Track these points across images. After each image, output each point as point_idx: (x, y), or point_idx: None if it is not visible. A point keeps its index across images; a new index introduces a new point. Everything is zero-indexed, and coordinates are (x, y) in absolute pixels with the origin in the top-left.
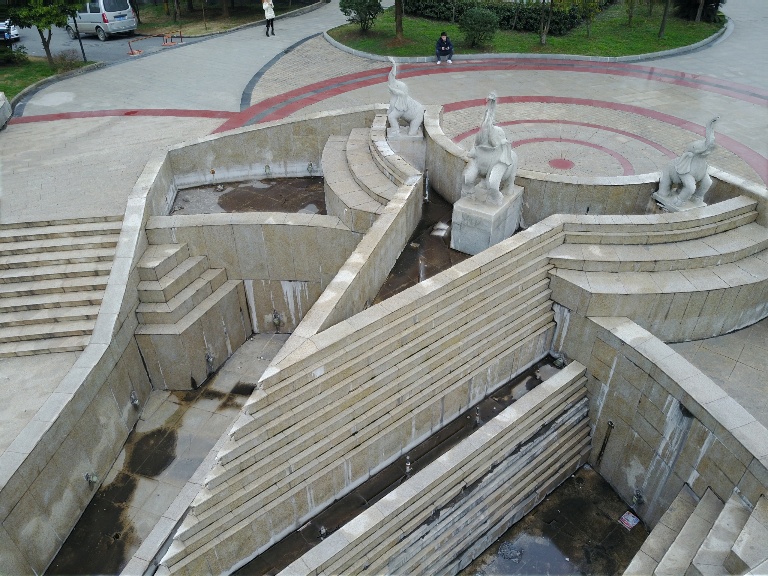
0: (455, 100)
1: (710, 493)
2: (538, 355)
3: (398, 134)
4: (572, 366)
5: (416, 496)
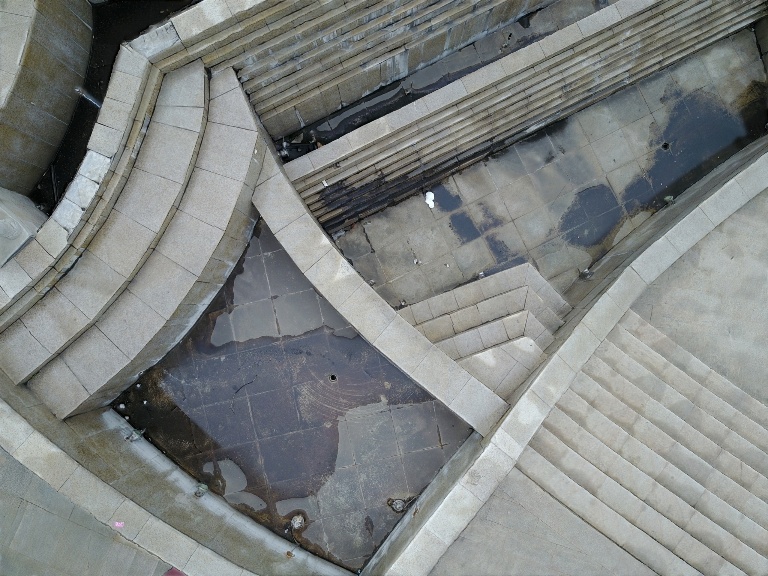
0: None
1: None
2: None
3: (9, 220)
4: None
5: None
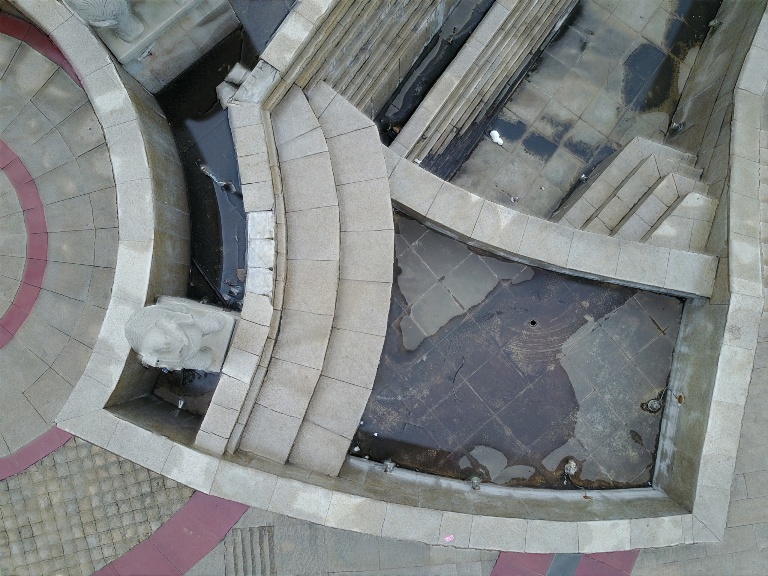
0: None
1: None
2: None
3: None
4: None
5: None
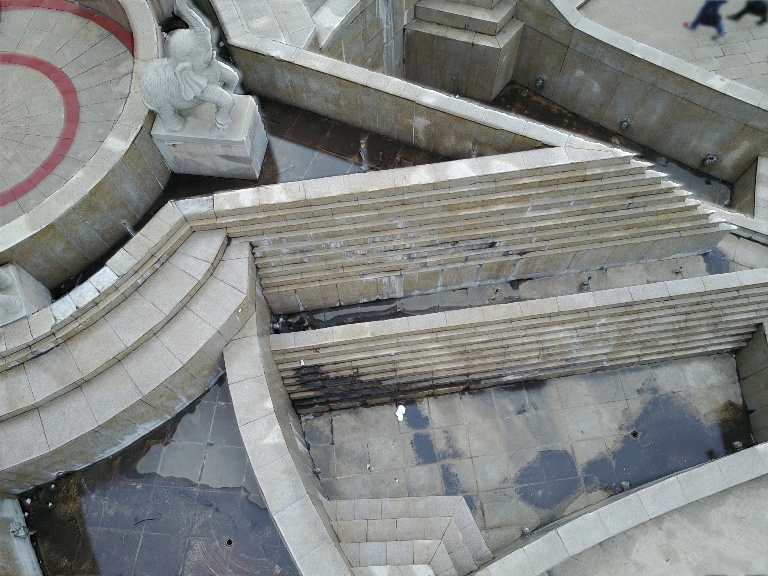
0: None
1: (420, 4)
2: None
3: (16, 298)
4: None
5: None
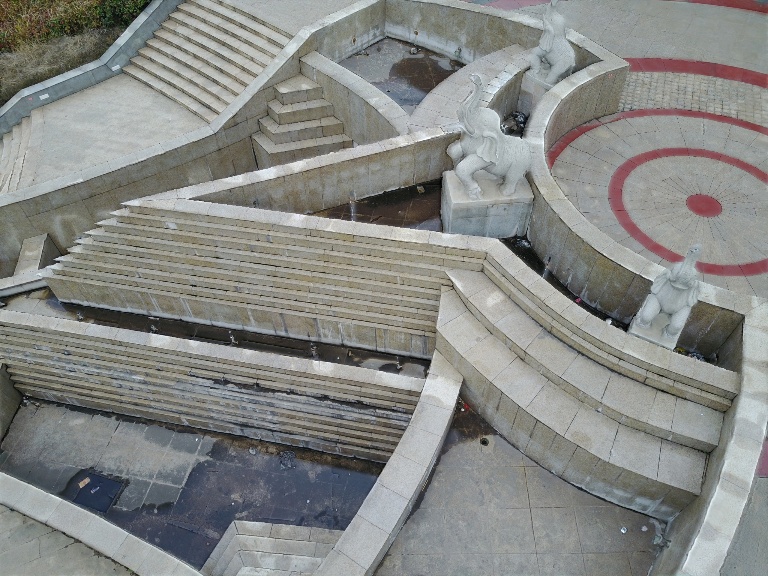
0: (741, 64)
1: None
2: (418, 352)
3: (535, 74)
4: (422, 382)
5: (208, 357)
